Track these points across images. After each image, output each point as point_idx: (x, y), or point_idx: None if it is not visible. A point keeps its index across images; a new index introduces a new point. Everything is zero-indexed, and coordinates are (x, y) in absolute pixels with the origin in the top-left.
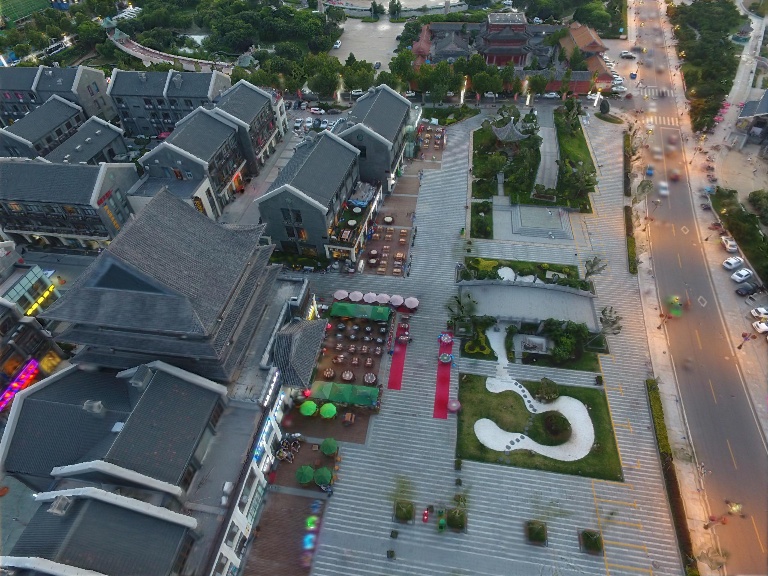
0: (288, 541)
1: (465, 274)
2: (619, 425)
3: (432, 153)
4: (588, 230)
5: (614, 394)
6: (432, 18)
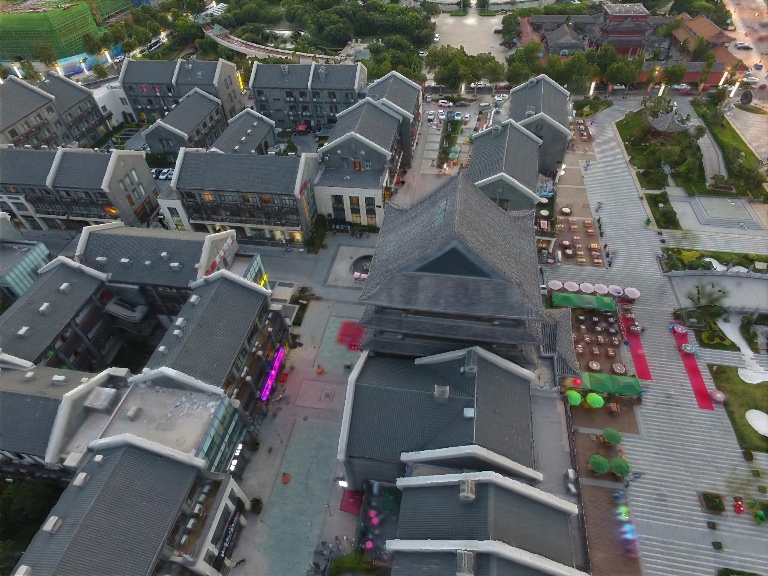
0: (603, 531)
1: (672, 264)
2: None
3: (581, 144)
4: None
5: None
6: (530, 11)
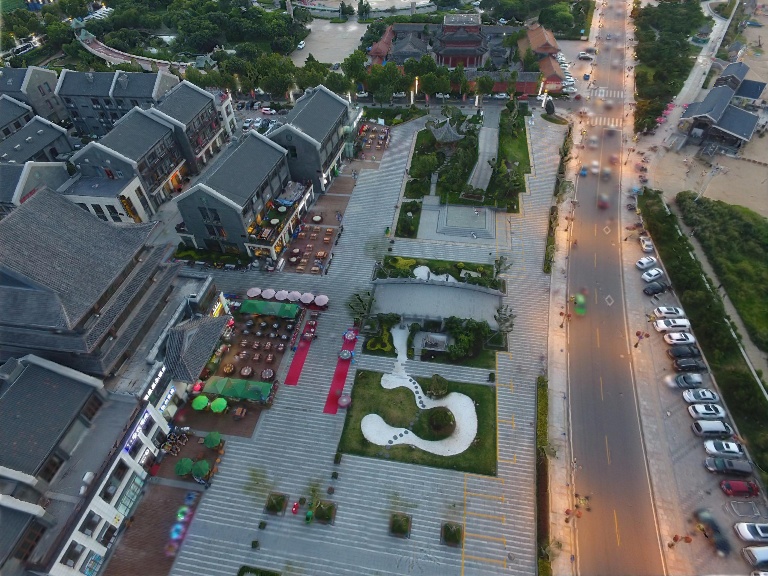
0: (159, 531)
1: (380, 272)
2: (503, 421)
3: (373, 153)
4: (511, 230)
5: (504, 391)
6: (396, 19)
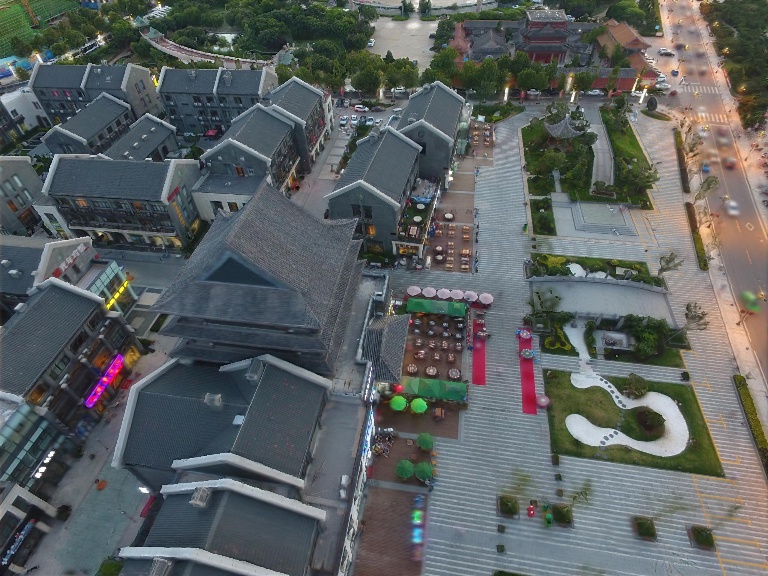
0: (395, 535)
1: (535, 270)
2: (712, 421)
3: (483, 150)
4: (652, 227)
5: (702, 390)
6: (465, 16)
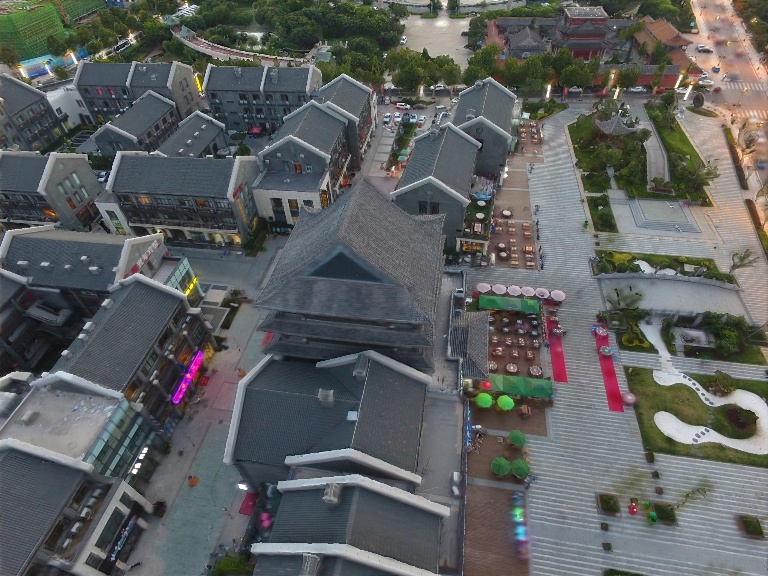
0: (497, 533)
1: (602, 267)
2: None
3: (531, 147)
4: (714, 223)
5: None
6: (497, 13)
